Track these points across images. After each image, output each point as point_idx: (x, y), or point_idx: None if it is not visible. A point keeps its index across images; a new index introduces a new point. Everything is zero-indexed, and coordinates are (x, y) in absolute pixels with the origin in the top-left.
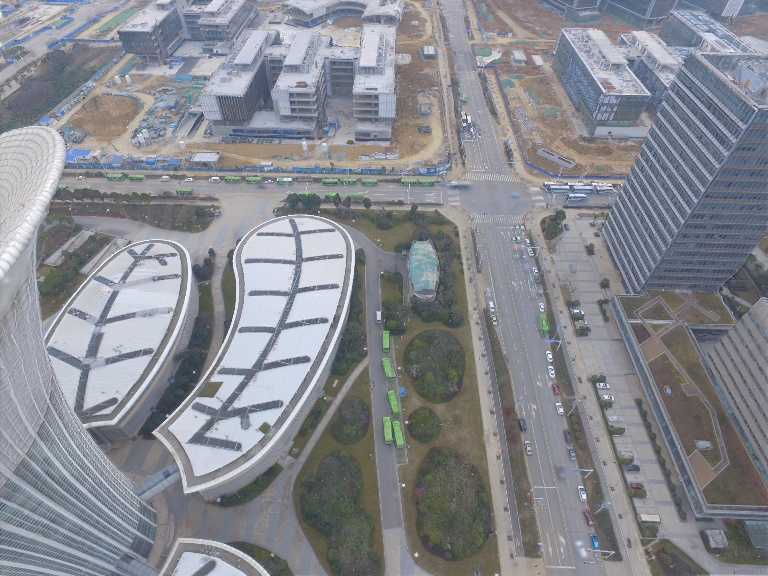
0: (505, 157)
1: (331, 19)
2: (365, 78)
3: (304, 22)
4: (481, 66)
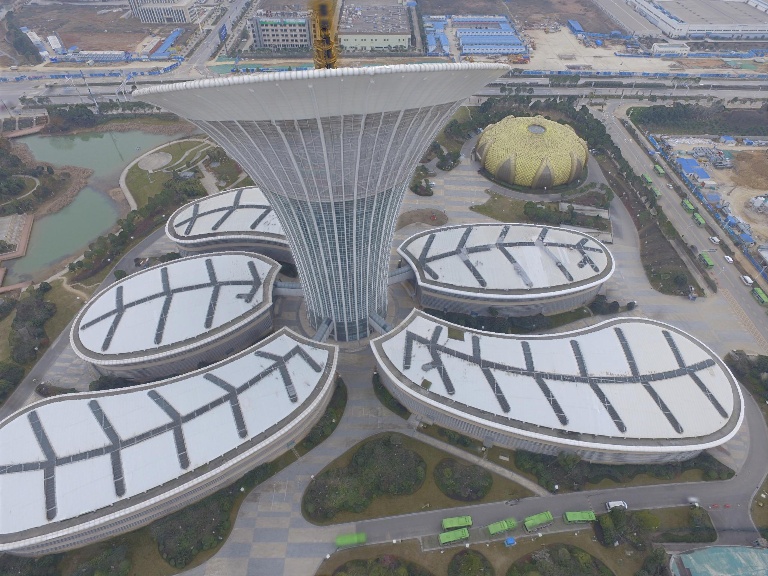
0: None
1: None
2: None
3: None
4: None
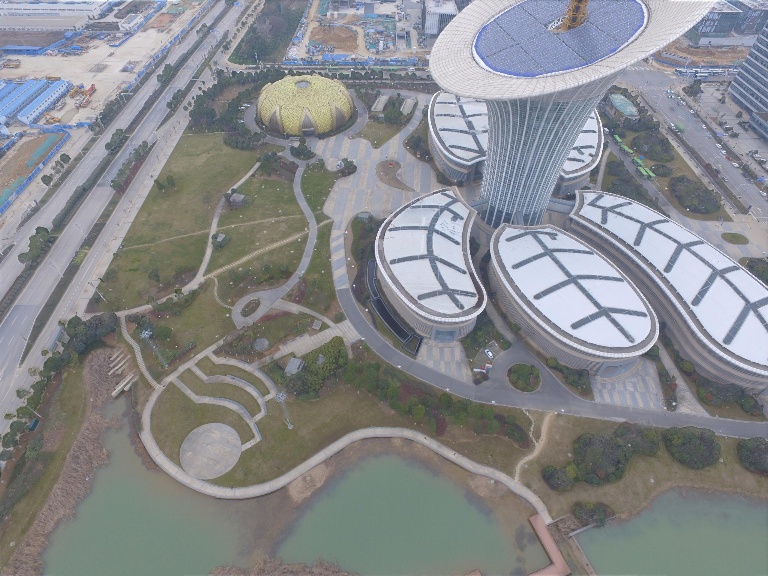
0: None
1: None
2: None
3: None
4: None
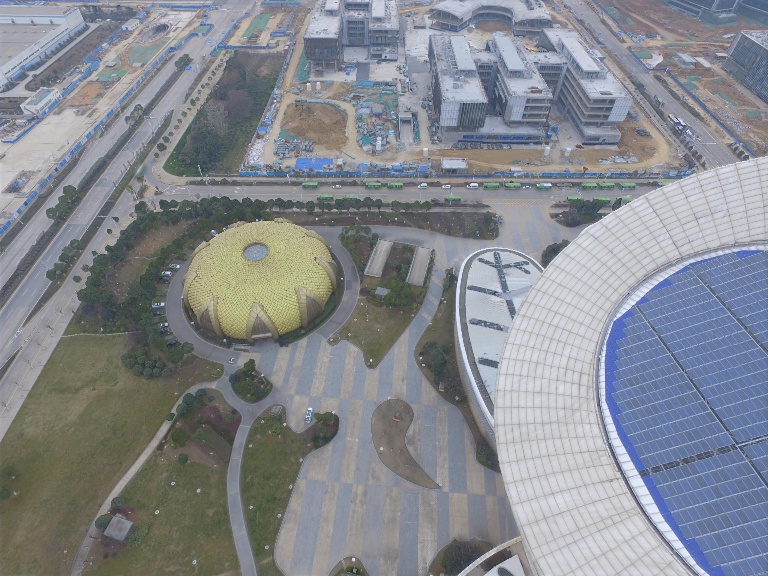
0: (737, 159)
1: (472, 23)
2: (591, 83)
3: (451, 26)
4: (652, 69)
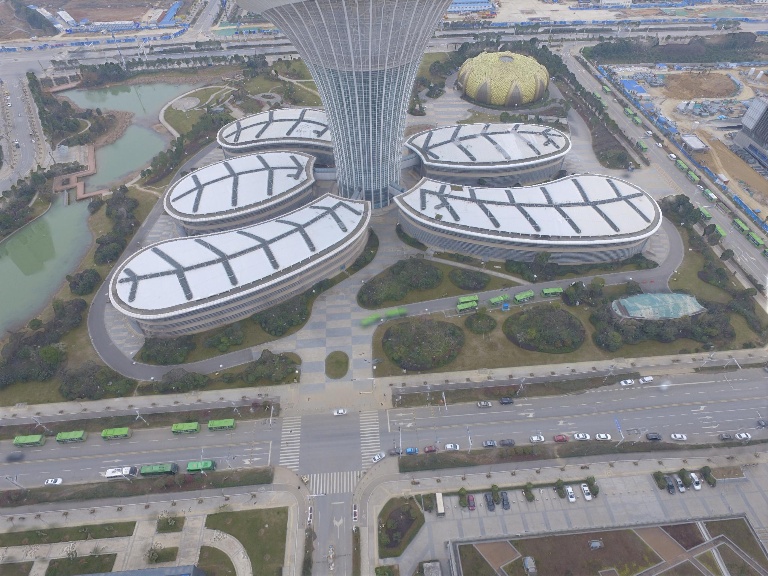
0: None
1: None
2: None
3: None
4: None
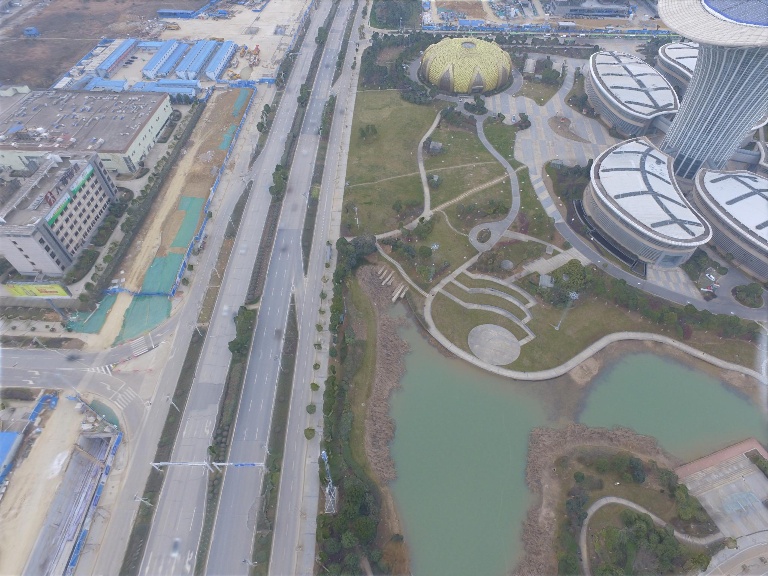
0: None
1: None
2: None
3: None
4: None
